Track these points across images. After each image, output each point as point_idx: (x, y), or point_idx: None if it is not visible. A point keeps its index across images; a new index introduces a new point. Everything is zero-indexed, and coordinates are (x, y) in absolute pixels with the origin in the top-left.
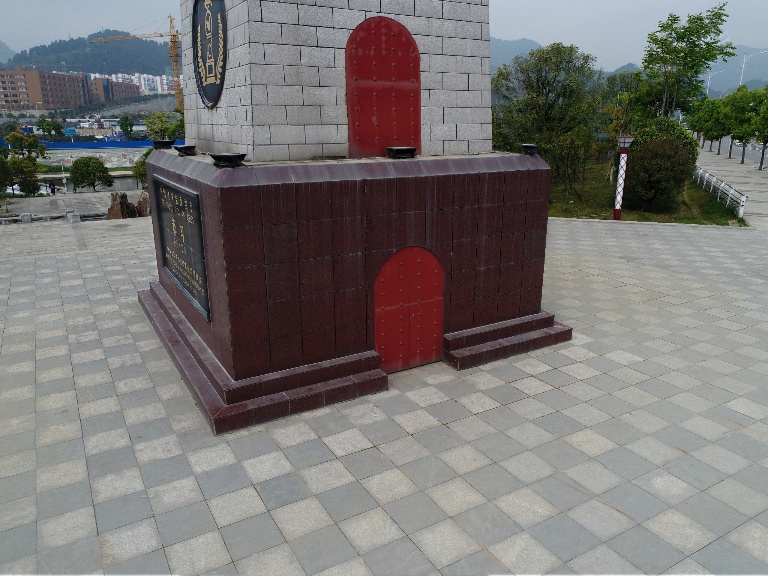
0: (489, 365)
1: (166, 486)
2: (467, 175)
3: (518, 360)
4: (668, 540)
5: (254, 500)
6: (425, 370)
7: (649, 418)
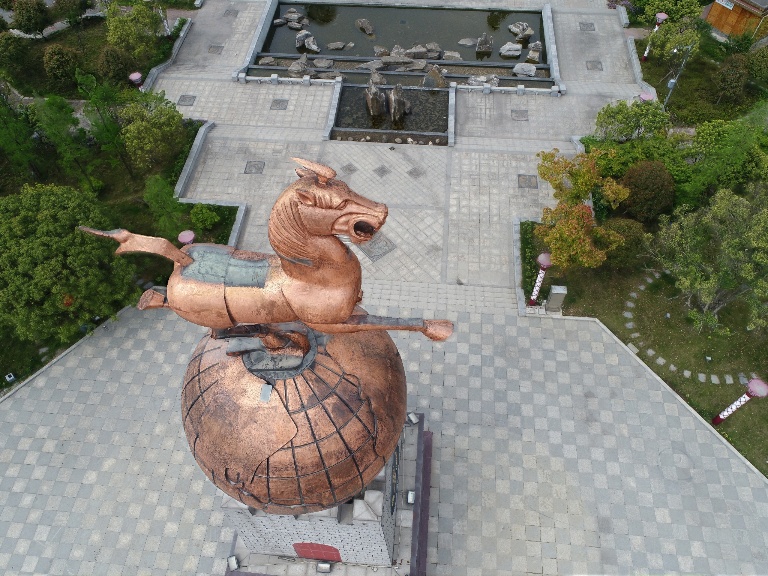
0: None
1: None
2: None
3: None
4: None
5: None
6: None
7: None
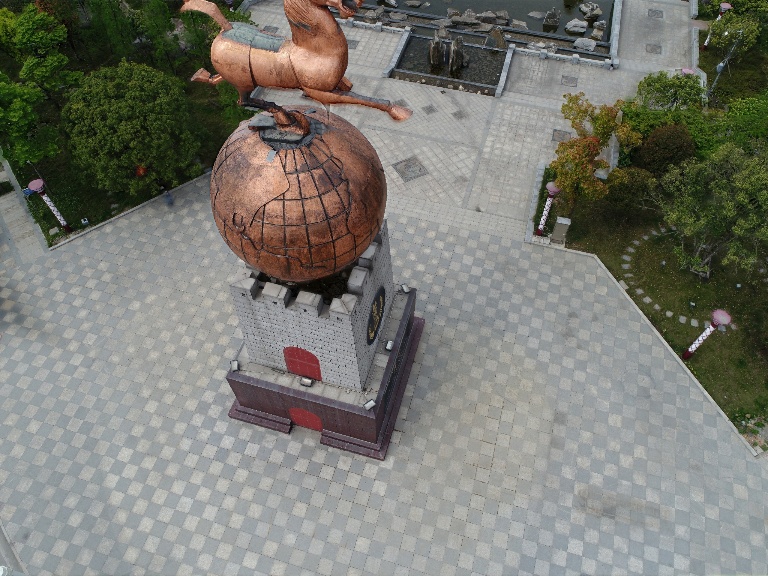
0: (333, 449)
1: (204, 430)
2: (326, 405)
3: (346, 455)
4: (264, 548)
5: (214, 453)
6: (312, 433)
7: (329, 518)
